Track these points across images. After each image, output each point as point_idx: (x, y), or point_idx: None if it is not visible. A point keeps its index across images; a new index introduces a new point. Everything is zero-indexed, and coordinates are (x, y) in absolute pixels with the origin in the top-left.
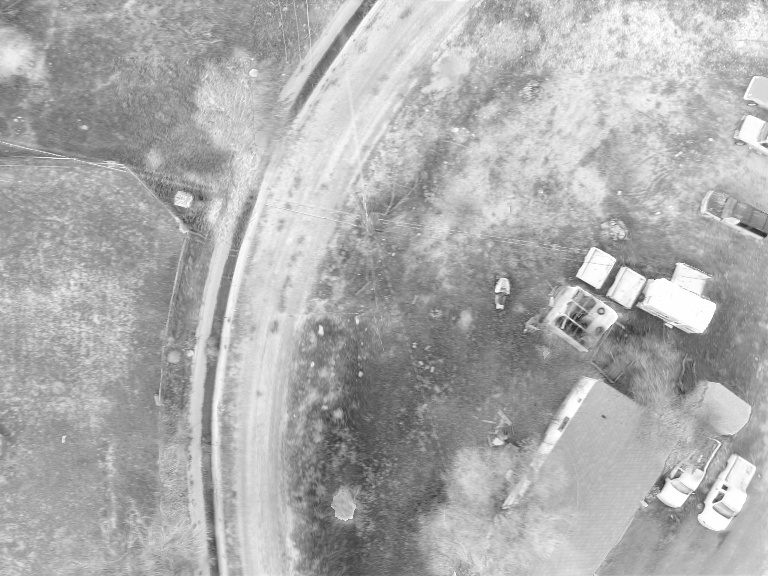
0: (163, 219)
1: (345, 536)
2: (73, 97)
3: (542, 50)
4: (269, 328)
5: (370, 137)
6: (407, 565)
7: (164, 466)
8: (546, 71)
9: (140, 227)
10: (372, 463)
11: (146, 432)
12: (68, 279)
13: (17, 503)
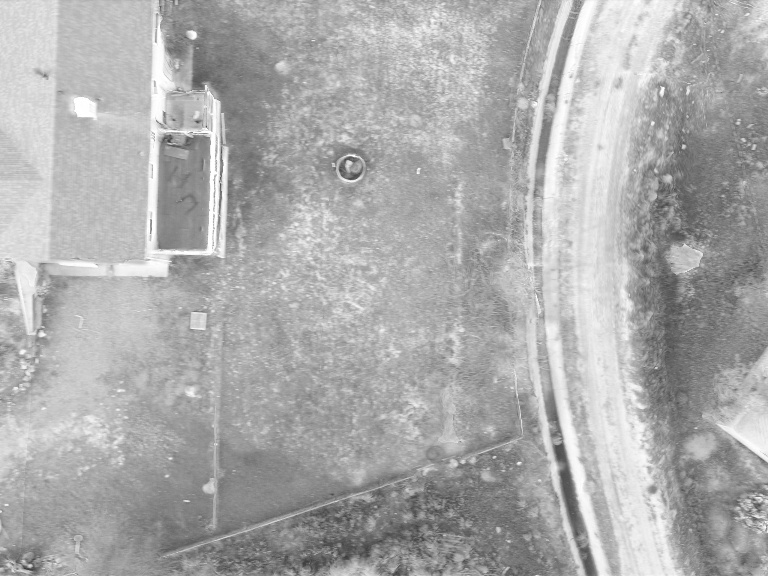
0: None
1: (664, 302)
2: None
3: None
4: (613, 84)
5: None
6: (720, 336)
7: (512, 206)
8: None
9: None
10: (694, 232)
11: (492, 174)
12: (429, 17)
13: (373, 228)
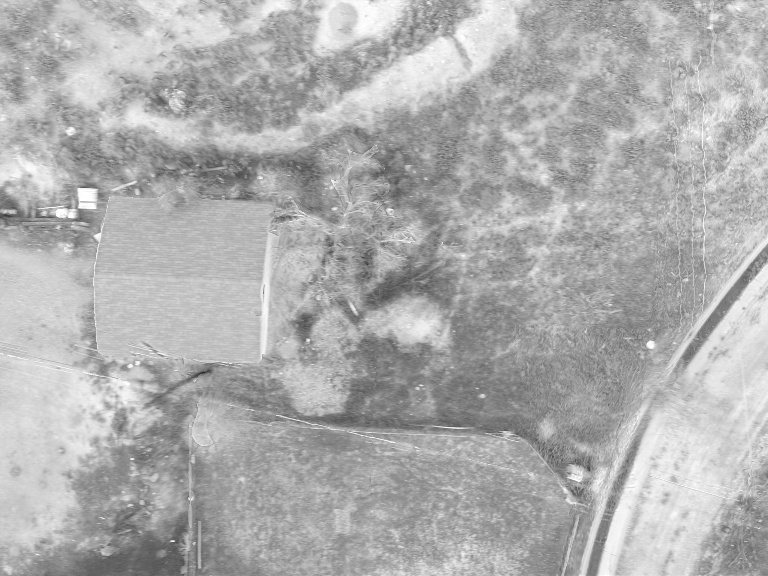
0: (552, 490)
1: None
2: (473, 365)
3: None
4: None
5: (760, 413)
6: None
7: None
8: None
9: (529, 497)
10: None
11: None
12: (459, 551)
13: None
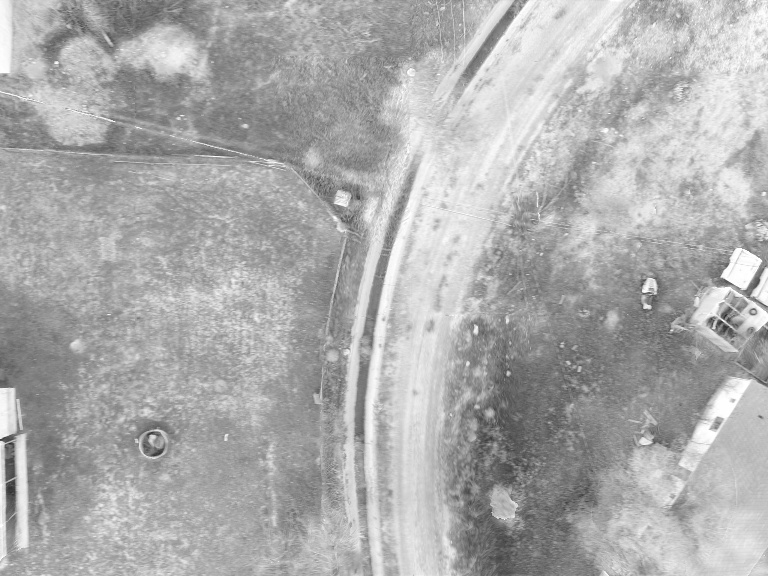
0: (321, 218)
1: (494, 535)
2: (234, 96)
3: (690, 51)
4: (425, 327)
5: (525, 137)
6: (555, 564)
7: (325, 464)
8: (694, 72)
9: (299, 226)
10: (521, 462)
11: (305, 430)
12: (229, 277)
13: (181, 501)
